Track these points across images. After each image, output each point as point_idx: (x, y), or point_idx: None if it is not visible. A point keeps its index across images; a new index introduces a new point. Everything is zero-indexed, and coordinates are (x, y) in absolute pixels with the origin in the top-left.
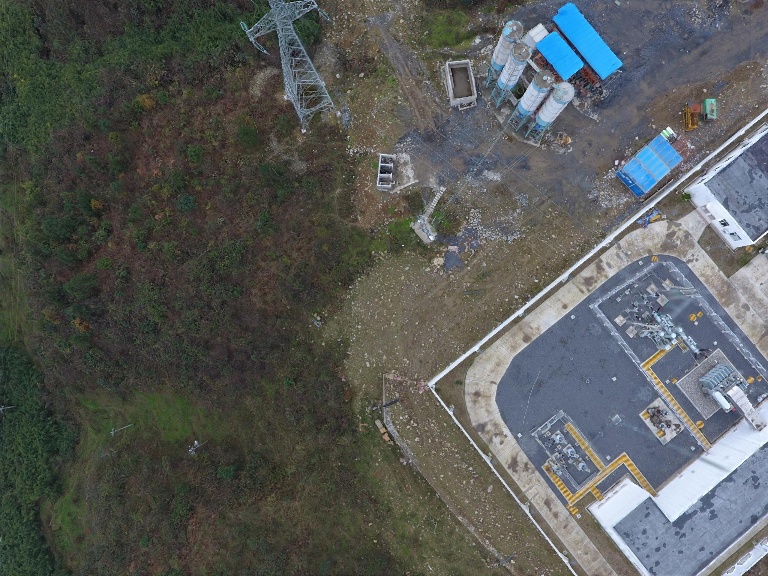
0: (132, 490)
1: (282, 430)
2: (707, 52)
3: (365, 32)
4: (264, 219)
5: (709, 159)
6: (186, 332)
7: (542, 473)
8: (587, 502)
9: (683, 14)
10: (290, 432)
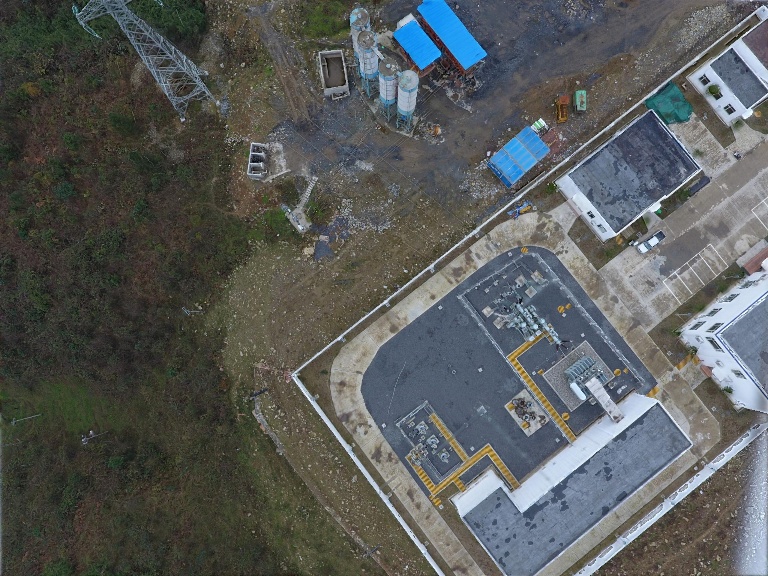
0: (33, 480)
1: (173, 420)
2: (581, 44)
3: (246, 22)
4: (140, 207)
5: (579, 151)
6: (67, 320)
7: (406, 463)
8: (450, 493)
9: (558, 6)
10: (179, 422)
